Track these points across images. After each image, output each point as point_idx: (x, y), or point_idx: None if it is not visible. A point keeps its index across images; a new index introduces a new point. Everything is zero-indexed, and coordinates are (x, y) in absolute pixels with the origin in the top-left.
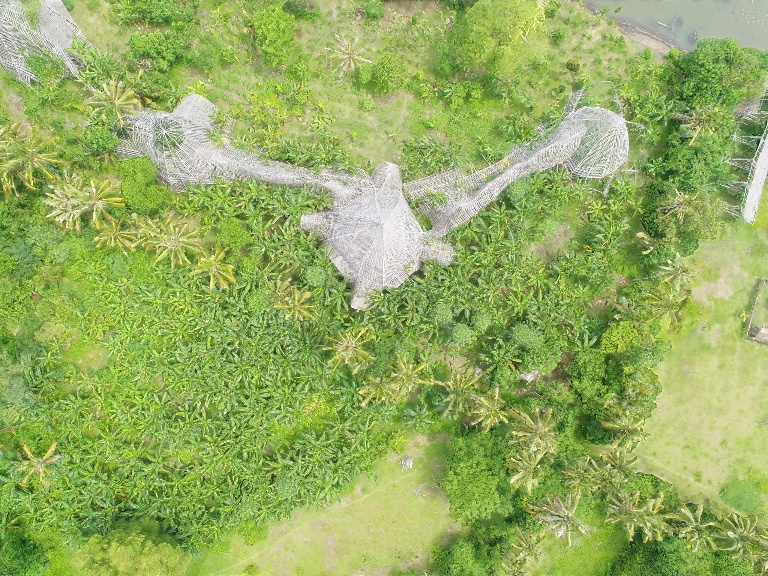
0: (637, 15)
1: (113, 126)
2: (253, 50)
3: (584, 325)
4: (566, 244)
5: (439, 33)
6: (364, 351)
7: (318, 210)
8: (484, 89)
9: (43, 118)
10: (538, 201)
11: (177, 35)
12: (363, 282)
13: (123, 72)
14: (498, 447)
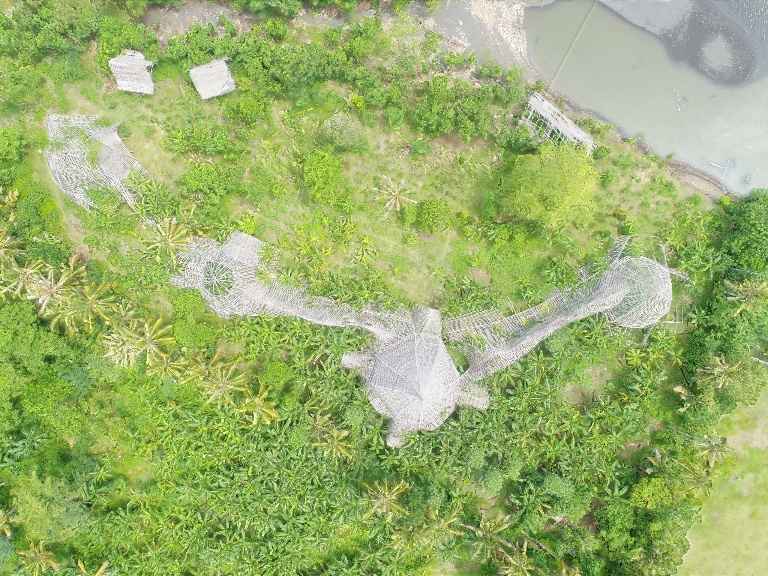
0: (689, 154)
1: (166, 266)
2: (301, 181)
3: (615, 471)
4: (602, 386)
5: (486, 170)
6: (398, 506)
7: (359, 349)
8: (528, 232)
9: (100, 241)
10: None
11: (229, 171)
12: (400, 424)
13: (176, 203)
14: None
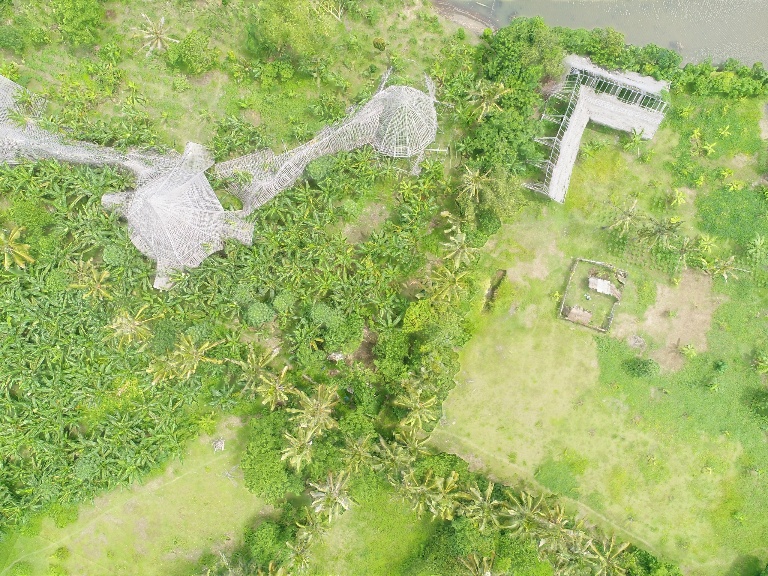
0: None
1: None
2: None
3: (392, 305)
4: (381, 224)
5: (253, 13)
6: (142, 328)
7: (122, 190)
8: (294, 69)
9: None
10: (344, 180)
11: None
12: (162, 261)
13: None
14: (290, 426)
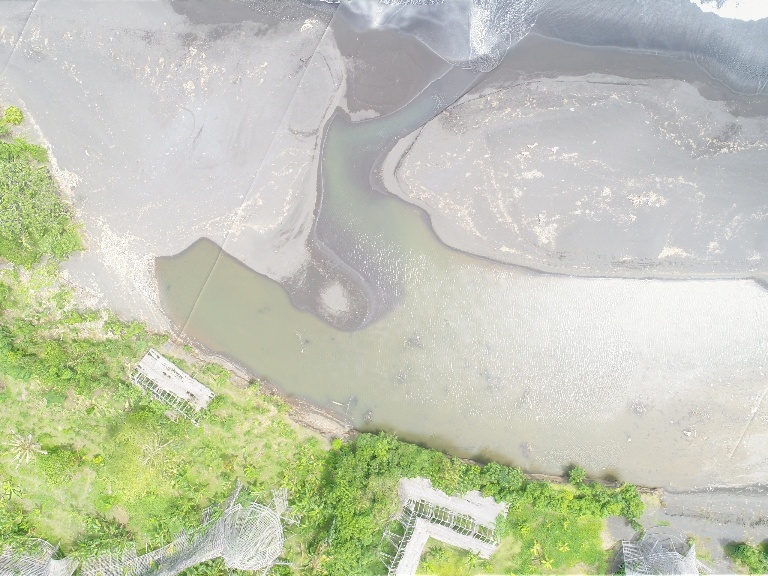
0: (315, 393)
1: None
2: None
3: None
4: None
5: (119, 416)
6: None
7: None
8: None
9: None
10: None
11: None
12: None
13: None
14: None
